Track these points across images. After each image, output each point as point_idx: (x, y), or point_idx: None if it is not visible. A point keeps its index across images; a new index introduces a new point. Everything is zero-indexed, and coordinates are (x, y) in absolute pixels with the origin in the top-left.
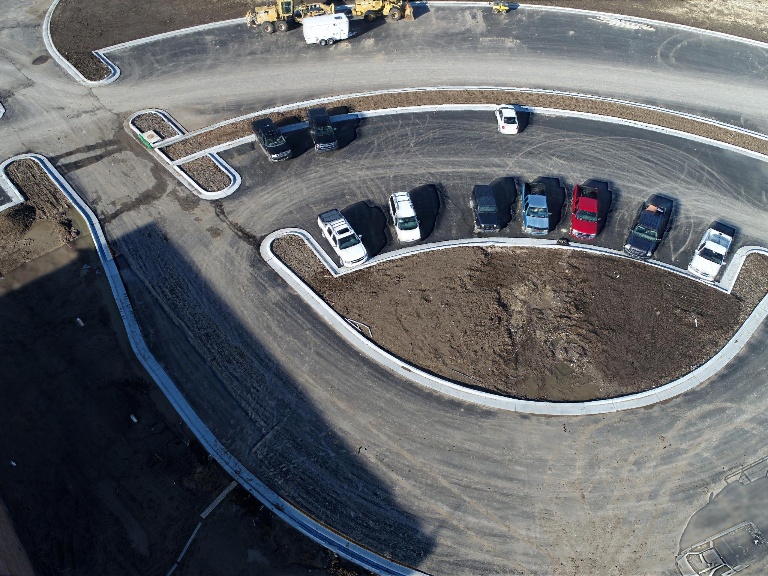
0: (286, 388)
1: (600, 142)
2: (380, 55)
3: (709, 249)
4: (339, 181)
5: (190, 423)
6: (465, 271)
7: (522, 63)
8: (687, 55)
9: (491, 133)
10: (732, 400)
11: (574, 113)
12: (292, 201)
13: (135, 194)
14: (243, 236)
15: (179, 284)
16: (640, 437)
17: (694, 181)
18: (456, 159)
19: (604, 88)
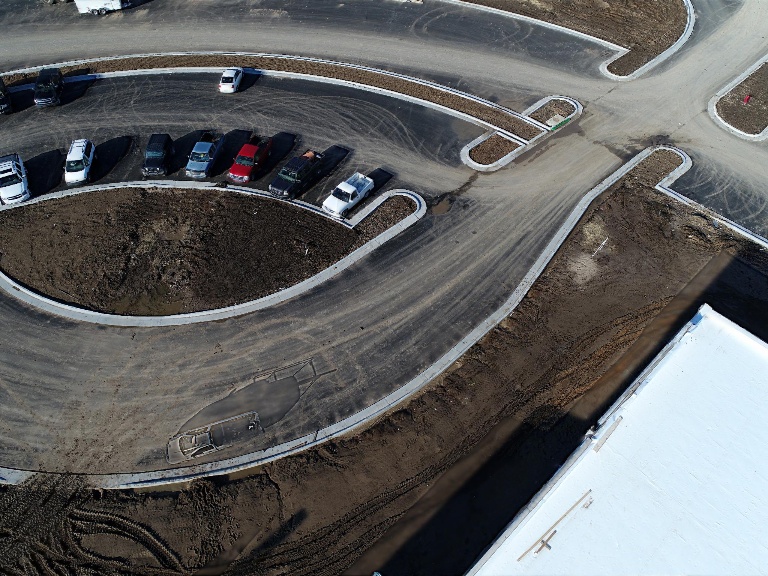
0: None
1: (312, 101)
2: (146, 24)
3: (339, 189)
4: (45, 132)
5: None
6: (116, 208)
7: (278, 32)
8: (440, 25)
9: (213, 92)
10: (301, 315)
11: (303, 75)
12: None
13: None
14: None
15: None
16: (198, 344)
17: (381, 134)
18: (166, 114)
19: (344, 54)
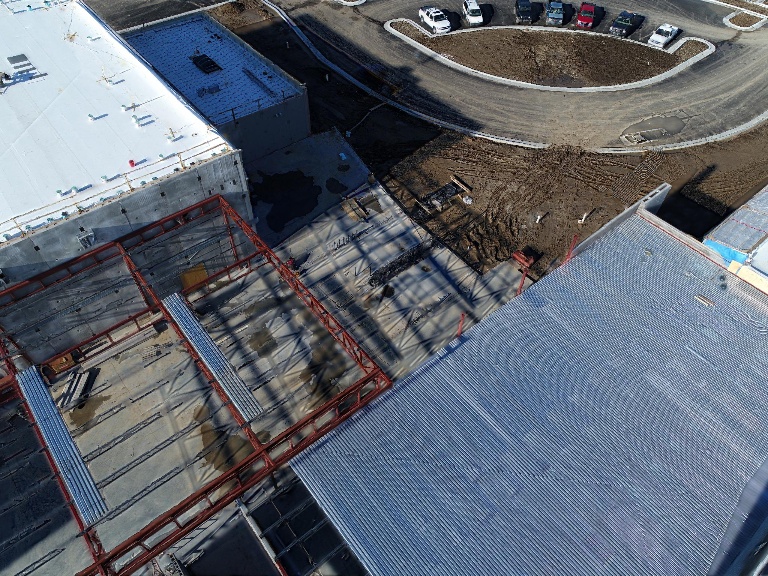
0: (407, 76)
1: None
2: None
3: (661, 29)
4: (429, 0)
5: (356, 84)
6: (510, 38)
7: None
8: None
9: None
10: (663, 91)
11: None
12: (401, 8)
13: (302, 1)
14: (372, 21)
15: (338, 37)
16: (607, 101)
17: (661, 9)
18: None
19: None
